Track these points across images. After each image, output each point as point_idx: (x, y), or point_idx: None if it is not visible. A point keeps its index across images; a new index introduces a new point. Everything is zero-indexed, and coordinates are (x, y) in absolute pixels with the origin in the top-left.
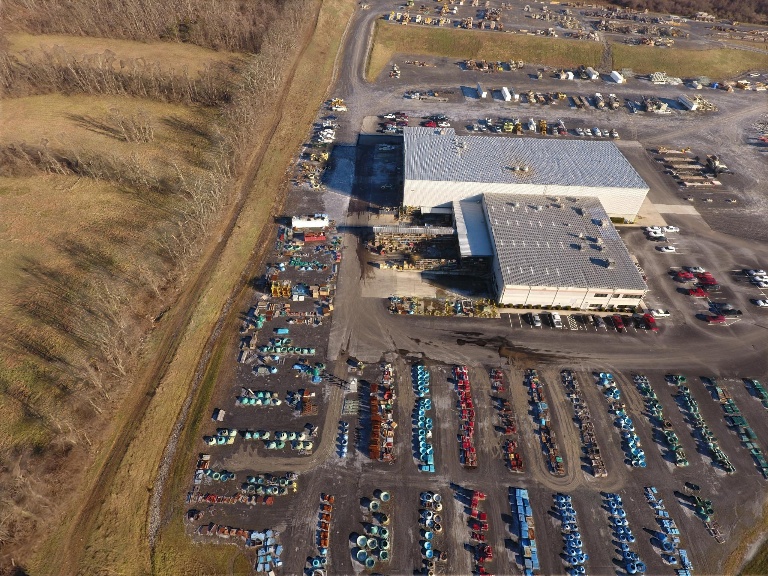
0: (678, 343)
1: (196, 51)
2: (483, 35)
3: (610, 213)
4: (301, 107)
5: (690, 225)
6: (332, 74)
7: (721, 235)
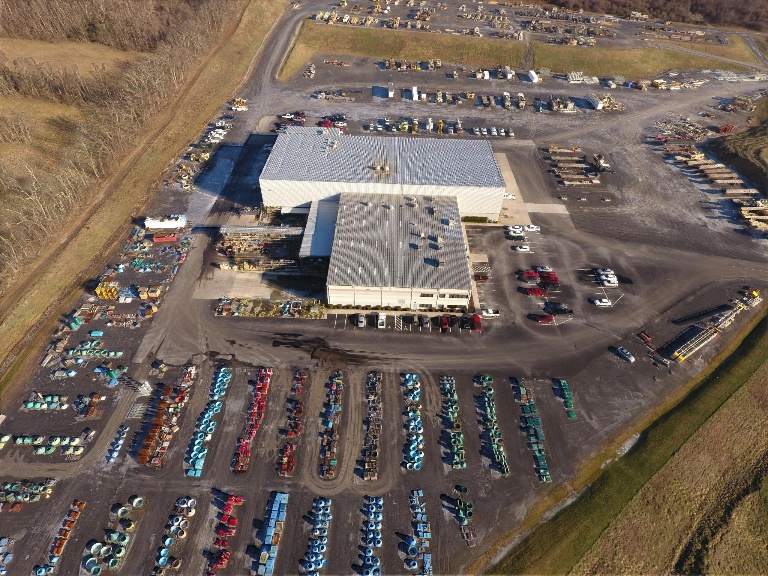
0: (499, 343)
1: (103, 51)
2: (407, 35)
3: (473, 212)
4: (200, 107)
5: (555, 224)
6: (245, 74)
7: (583, 234)
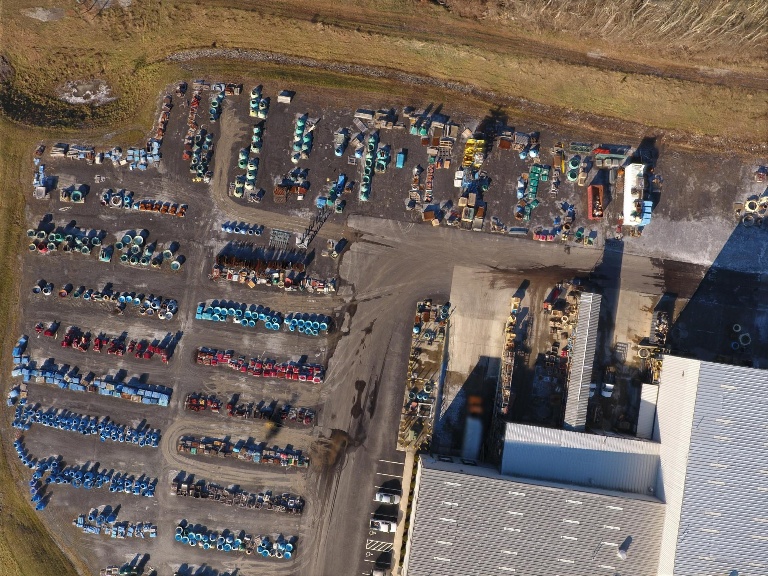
0: None
1: None
2: None
3: None
4: None
5: None
6: None
7: None
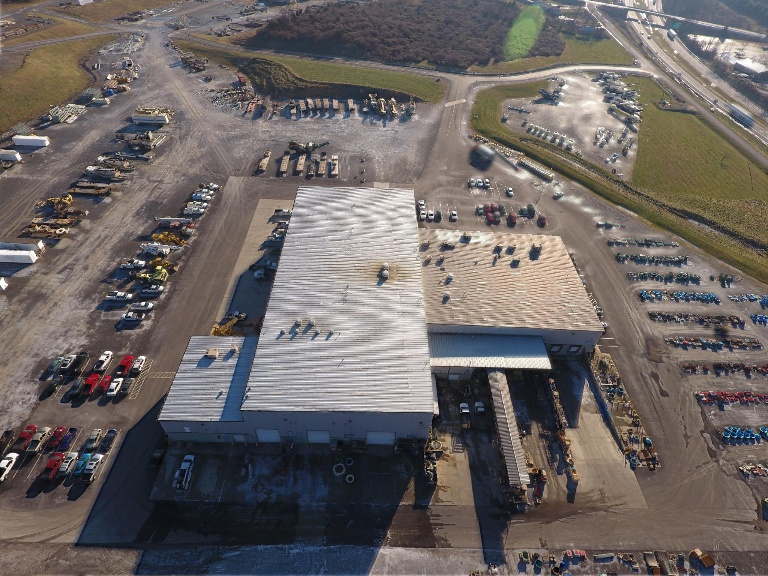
0: (578, 246)
1: None
2: None
3: None
4: None
5: None
6: None
7: (421, 182)
